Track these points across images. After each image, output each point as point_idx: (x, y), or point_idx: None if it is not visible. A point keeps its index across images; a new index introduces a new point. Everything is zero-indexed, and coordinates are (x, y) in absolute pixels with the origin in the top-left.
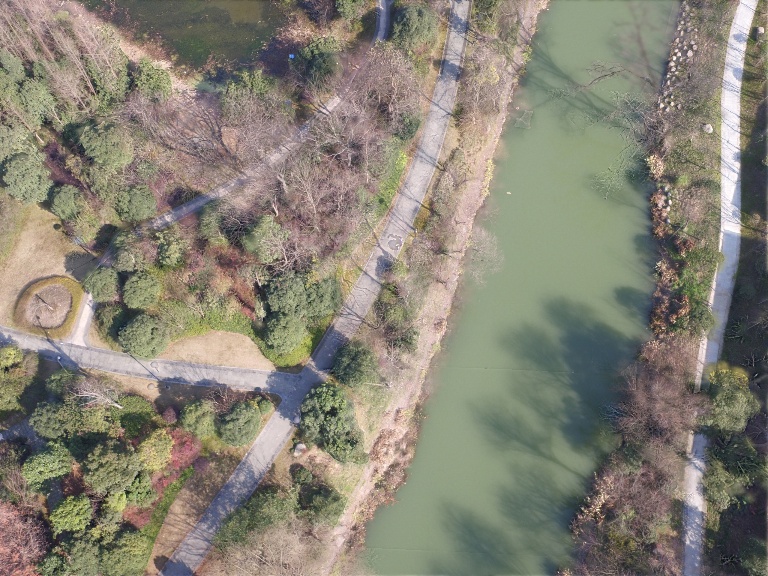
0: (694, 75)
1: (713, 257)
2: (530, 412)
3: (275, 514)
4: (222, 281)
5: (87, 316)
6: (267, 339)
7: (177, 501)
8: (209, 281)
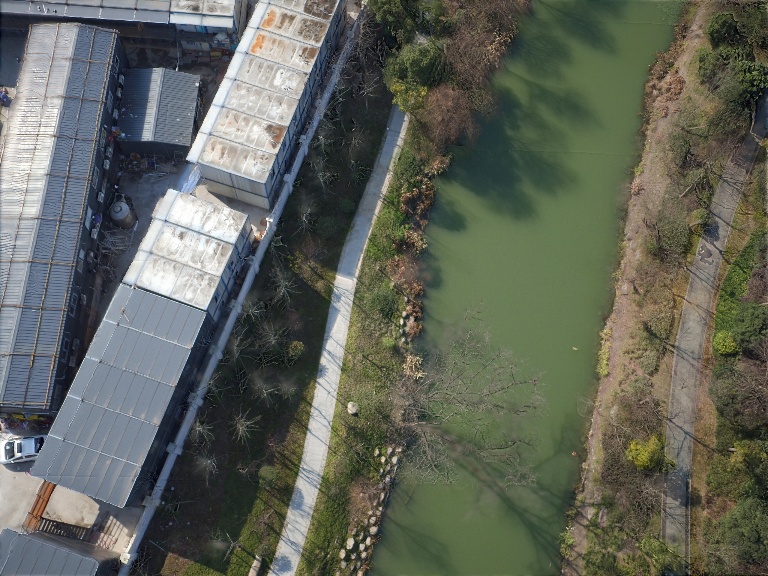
0: (352, 503)
1: None
2: (549, 118)
3: (759, 29)
4: None
5: None
6: None
7: None
8: None
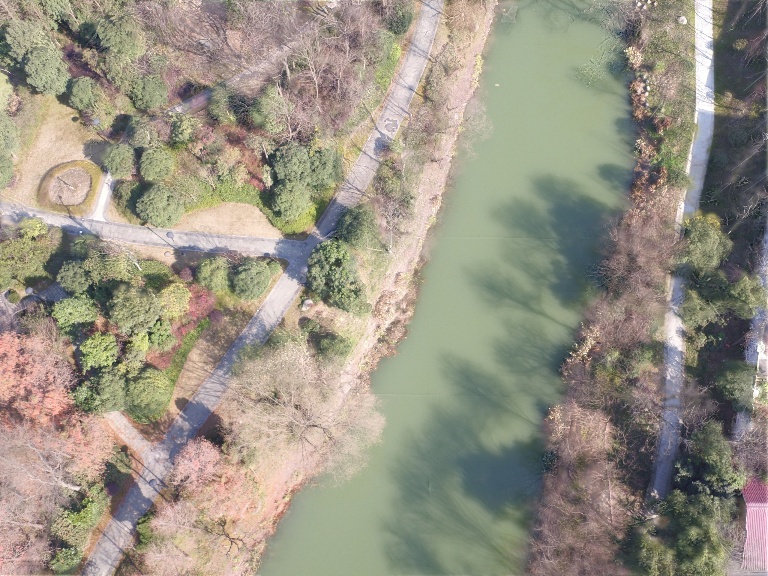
0: None
1: (688, 127)
2: (521, 274)
3: (286, 360)
4: (231, 155)
5: (106, 195)
6: (275, 205)
7: (195, 350)
8: (219, 156)
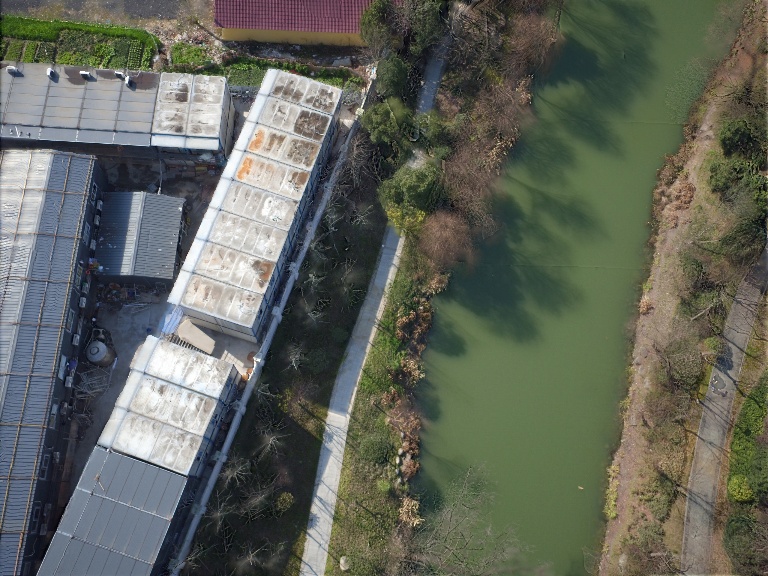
0: None
1: None
2: (553, 228)
3: None
4: None
5: None
6: None
7: None
8: None
